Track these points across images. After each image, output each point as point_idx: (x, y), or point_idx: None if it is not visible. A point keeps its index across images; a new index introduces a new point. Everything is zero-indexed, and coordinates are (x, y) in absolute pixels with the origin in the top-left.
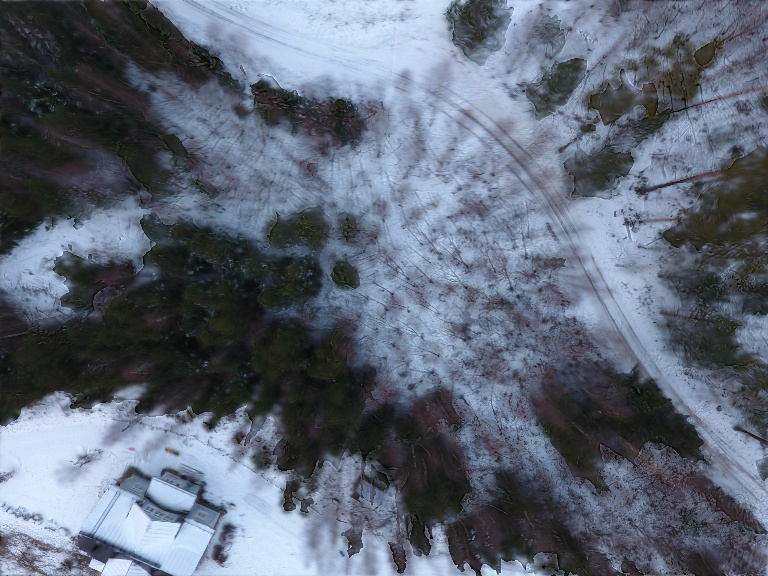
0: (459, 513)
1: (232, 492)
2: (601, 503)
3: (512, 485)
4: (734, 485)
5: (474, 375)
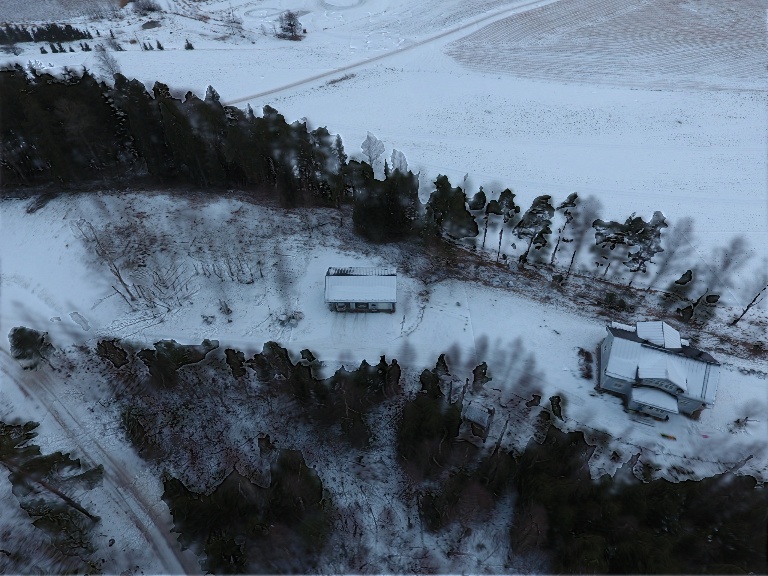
0: (390, 405)
1: (597, 406)
2: (255, 425)
3: (364, 437)
4: (117, 455)
5: (401, 556)
